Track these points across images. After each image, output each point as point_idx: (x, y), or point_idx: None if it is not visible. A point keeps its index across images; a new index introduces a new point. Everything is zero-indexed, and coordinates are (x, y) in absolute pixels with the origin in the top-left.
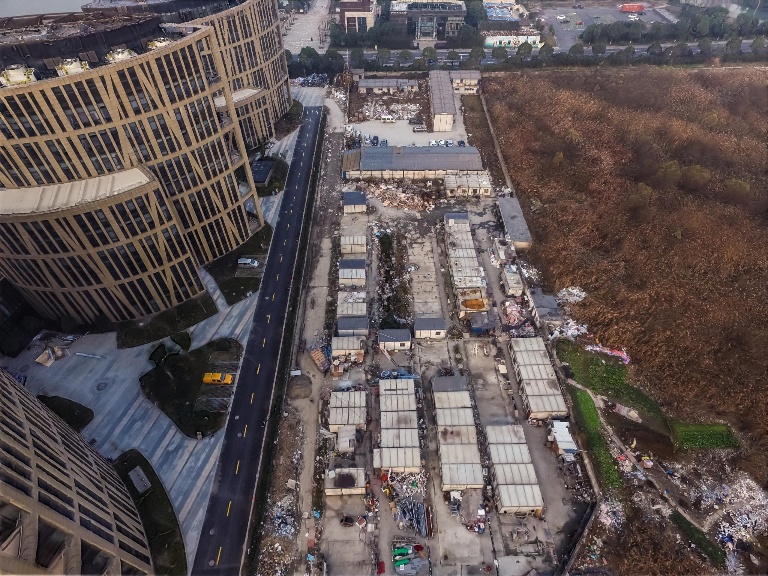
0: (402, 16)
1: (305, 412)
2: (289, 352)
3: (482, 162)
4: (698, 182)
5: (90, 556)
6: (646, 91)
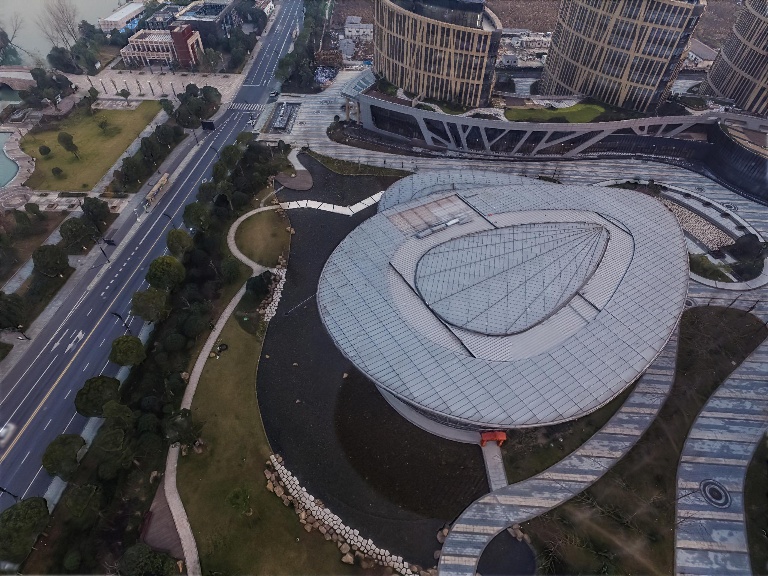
0: (219, 22)
1: None
2: None
3: None
4: None
5: None
6: None
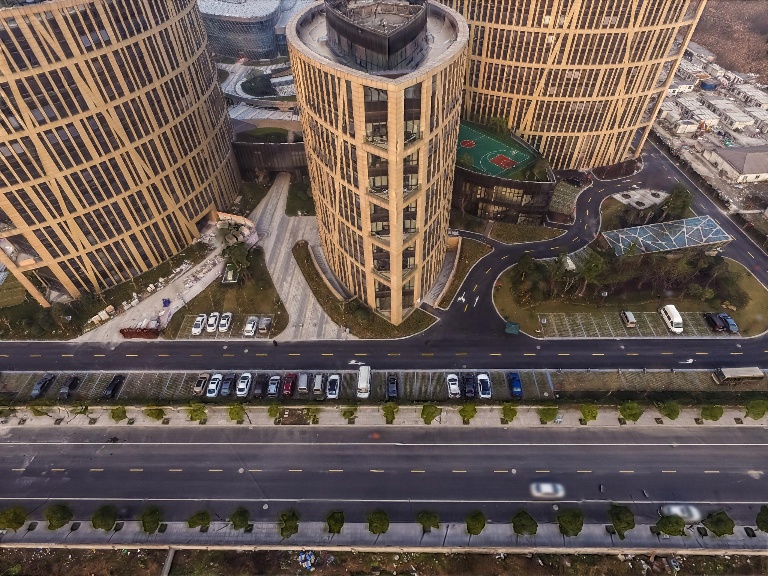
0: None
1: None
2: None
3: None
4: None
5: None
6: None
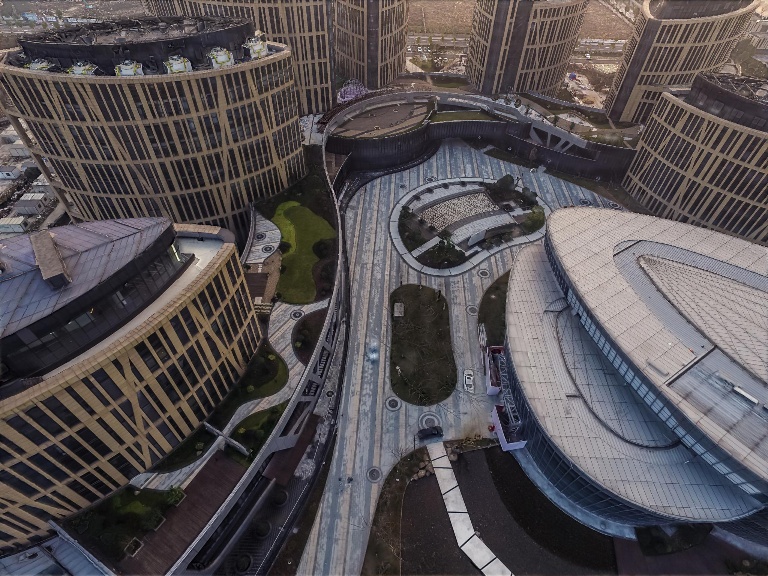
0: None
1: None
2: None
3: None
4: None
5: None
6: None
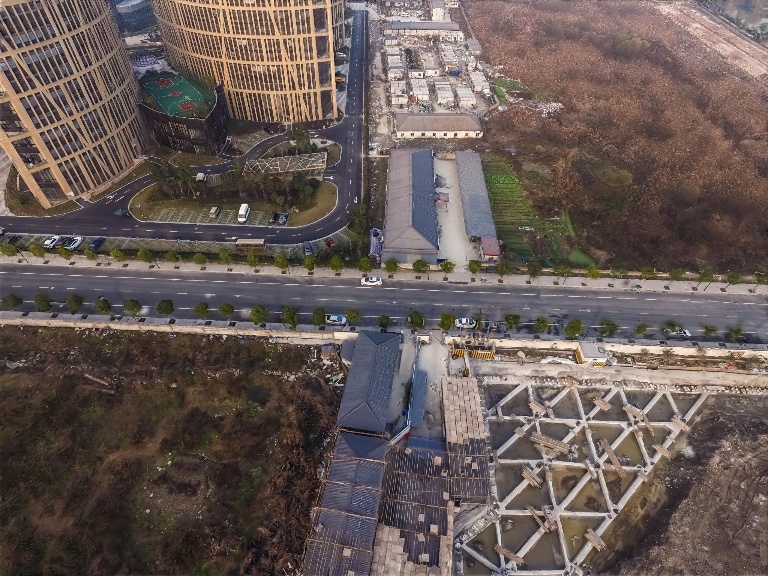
0: None
1: (379, 90)
2: (368, 77)
3: (459, 27)
4: (572, 34)
5: (327, 68)
6: (558, 3)
